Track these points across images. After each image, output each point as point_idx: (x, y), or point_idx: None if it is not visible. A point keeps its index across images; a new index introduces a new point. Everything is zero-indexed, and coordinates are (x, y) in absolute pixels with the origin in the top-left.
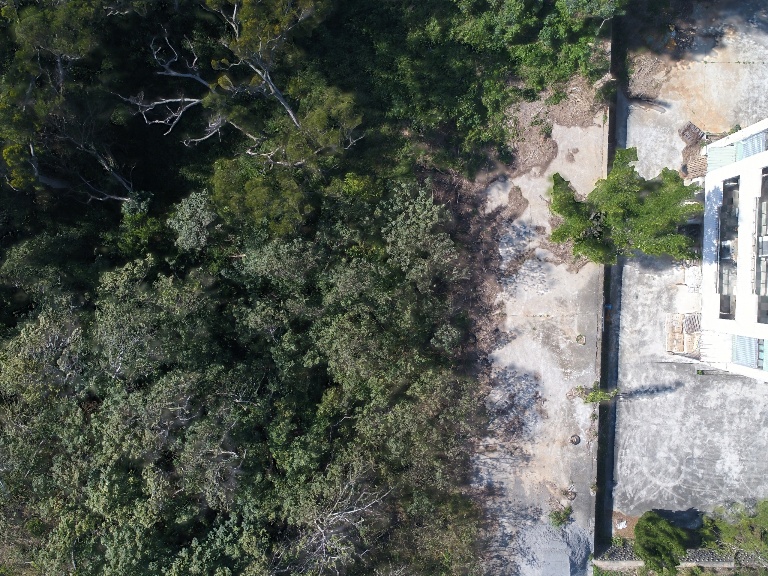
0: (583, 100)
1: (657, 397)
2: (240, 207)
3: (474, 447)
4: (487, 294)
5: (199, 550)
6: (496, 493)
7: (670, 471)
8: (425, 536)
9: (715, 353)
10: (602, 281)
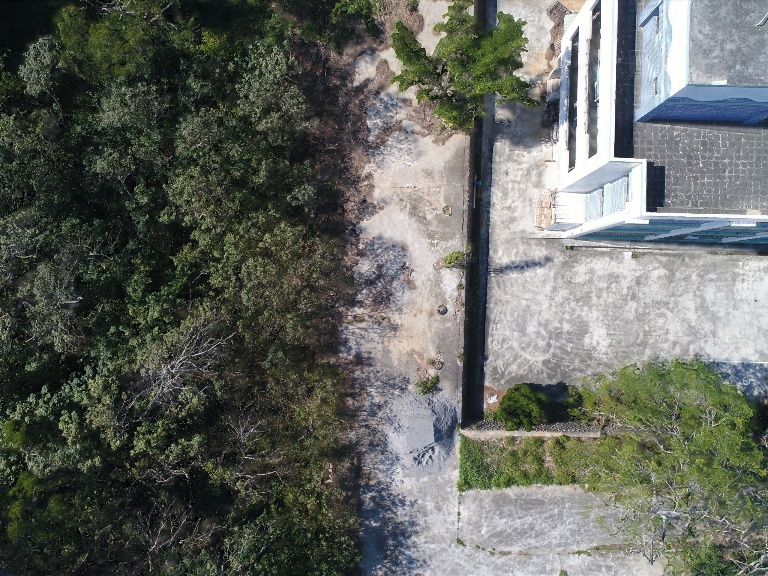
0: None
1: (527, 272)
2: (84, 50)
3: (342, 317)
4: (355, 165)
5: (48, 397)
6: (364, 363)
7: (540, 345)
8: (279, 389)
9: (569, 214)
10: (468, 153)
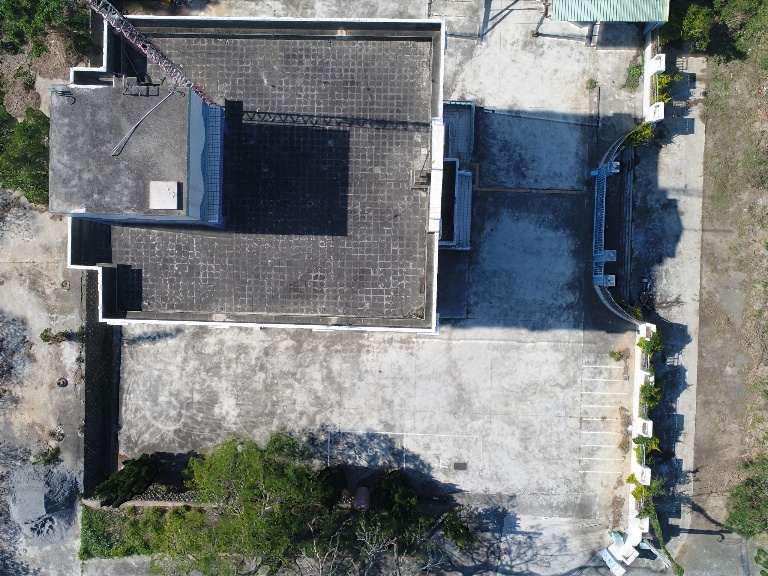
0: (59, 52)
1: (159, 343)
2: None
3: None
4: None
5: None
6: None
7: (171, 415)
8: None
9: None
10: None
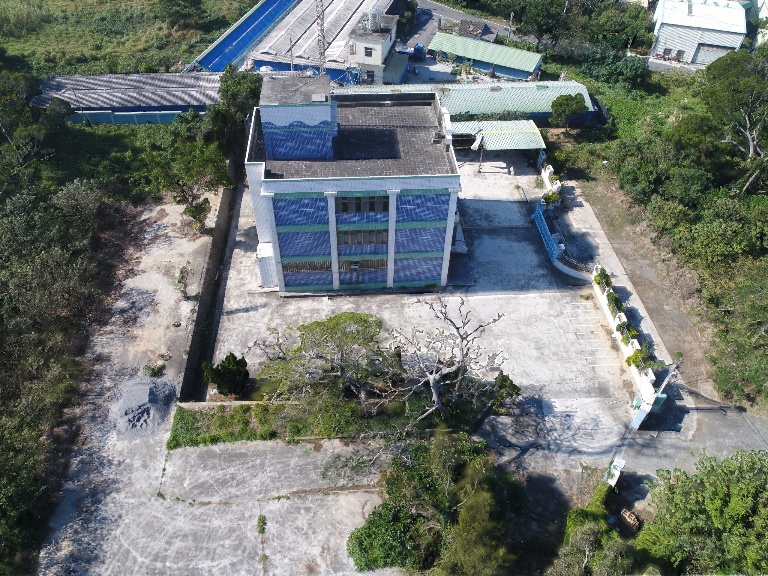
0: None
1: (251, 311)
2: None
3: (95, 332)
4: (130, 253)
5: None
6: (104, 359)
7: (257, 353)
8: None
9: (265, 253)
10: (210, 245)
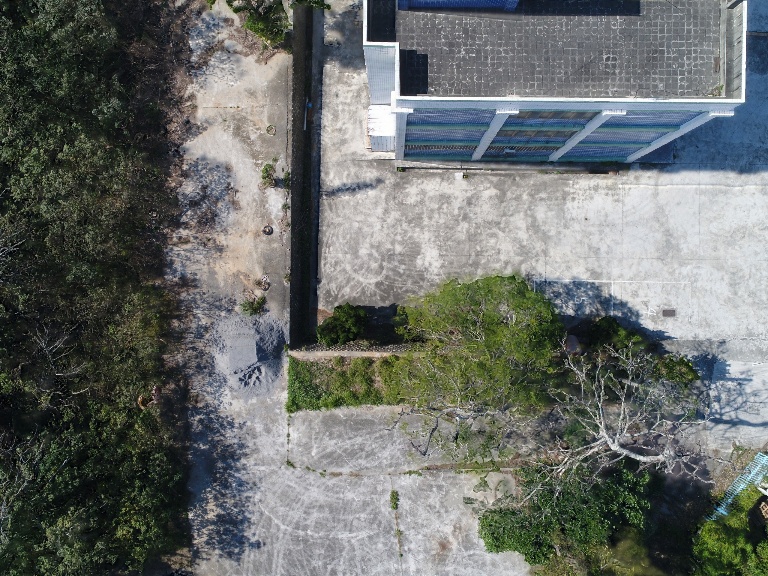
0: None
1: (358, 194)
2: None
3: (167, 239)
4: (177, 86)
5: None
6: (190, 284)
7: (372, 267)
8: (84, 303)
9: (381, 127)
10: (291, 72)
